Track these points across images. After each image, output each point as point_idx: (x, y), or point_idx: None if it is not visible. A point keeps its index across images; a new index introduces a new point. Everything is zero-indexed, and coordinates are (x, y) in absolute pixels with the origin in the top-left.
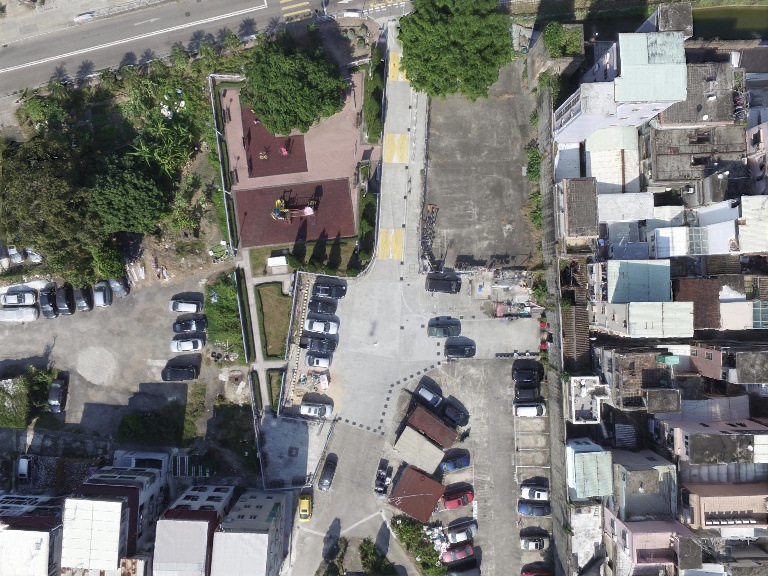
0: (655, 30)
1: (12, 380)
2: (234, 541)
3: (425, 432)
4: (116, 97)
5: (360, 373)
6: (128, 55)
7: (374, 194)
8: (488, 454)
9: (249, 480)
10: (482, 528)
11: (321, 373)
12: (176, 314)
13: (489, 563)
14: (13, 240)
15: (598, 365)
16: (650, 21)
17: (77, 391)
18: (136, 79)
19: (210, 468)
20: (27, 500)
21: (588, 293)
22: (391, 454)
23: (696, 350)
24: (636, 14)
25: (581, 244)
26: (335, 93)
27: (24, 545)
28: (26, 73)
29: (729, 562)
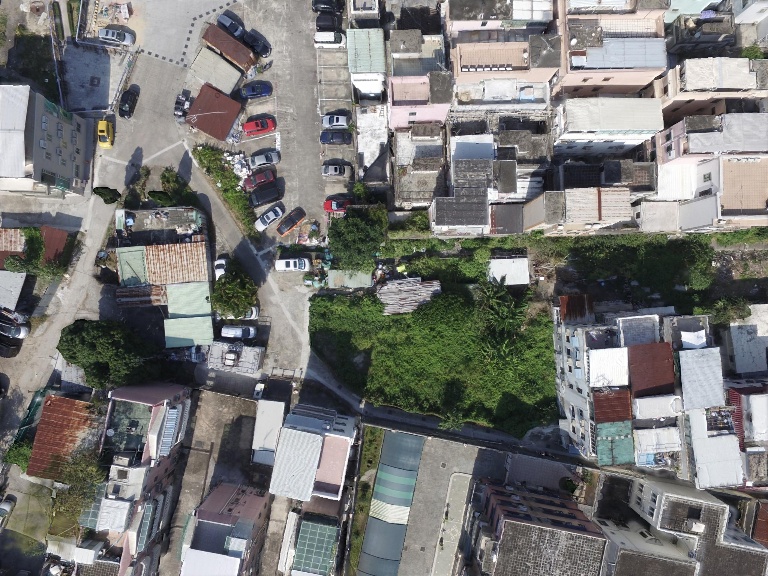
0: None
1: None
2: None
3: (219, 48)
4: None
5: (162, 6)
6: None
7: None
8: (291, 86)
9: None
10: (285, 159)
11: None
12: None
13: (293, 194)
14: None
15: None
16: None
17: None
18: None
19: None
20: None
21: None
22: (193, 85)
23: None
24: None
25: None
26: None
27: None
28: None
29: None
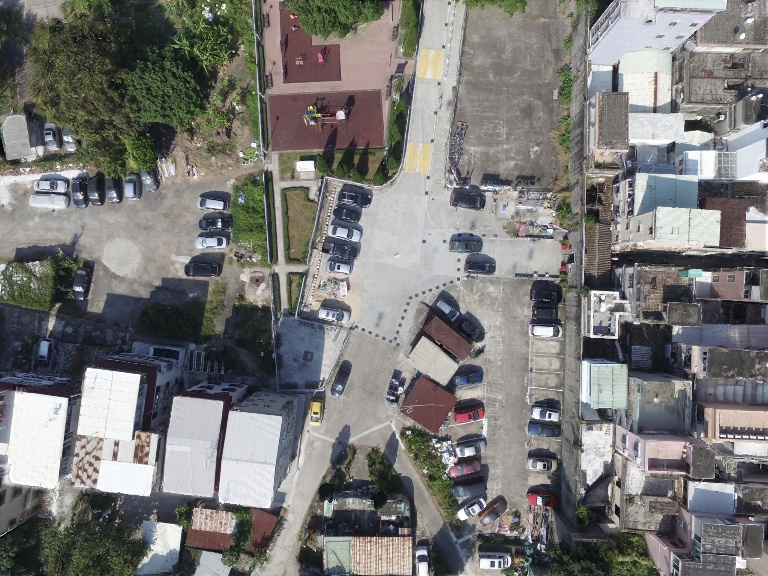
0: None
1: (39, 262)
2: (248, 420)
3: (441, 342)
4: None
5: (379, 283)
6: None
7: None
8: (501, 373)
9: (263, 381)
10: (491, 446)
11: (341, 280)
12: (203, 212)
13: (495, 482)
14: (53, 114)
15: (618, 285)
16: None
17: (101, 281)
18: None
19: (226, 365)
20: (46, 377)
21: (612, 214)
22: (405, 365)
23: (718, 276)
24: None
25: (609, 162)
26: None
27: (43, 407)
28: None
29: (740, 484)
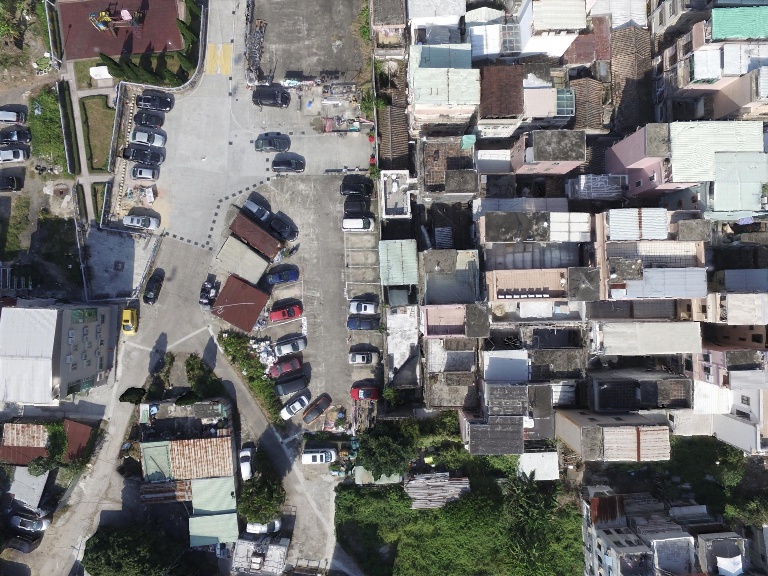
0: None
1: None
2: (22, 316)
3: (246, 239)
4: None
5: (188, 188)
6: None
7: None
8: (318, 270)
9: (74, 294)
10: (312, 344)
11: (148, 187)
12: None
13: (319, 380)
14: None
15: None
16: None
17: None
18: None
19: (33, 280)
20: None
21: None
22: (219, 269)
23: (513, 151)
24: None
25: (395, 42)
26: None
27: None
28: None
29: (534, 349)
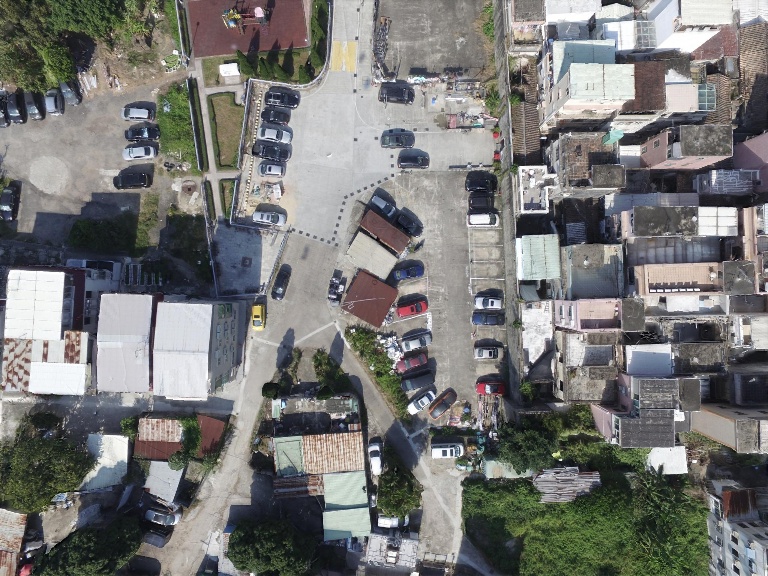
0: None
1: None
2: (178, 310)
3: (377, 235)
4: None
5: (314, 184)
6: None
7: None
8: (442, 266)
9: (202, 290)
10: (437, 340)
11: (274, 184)
12: (129, 124)
13: (444, 375)
14: None
15: (548, 163)
16: None
17: (29, 200)
18: None
19: (163, 276)
20: None
21: (539, 95)
22: (345, 265)
23: (646, 146)
24: None
25: (530, 39)
26: None
27: None
28: None
29: (677, 343)
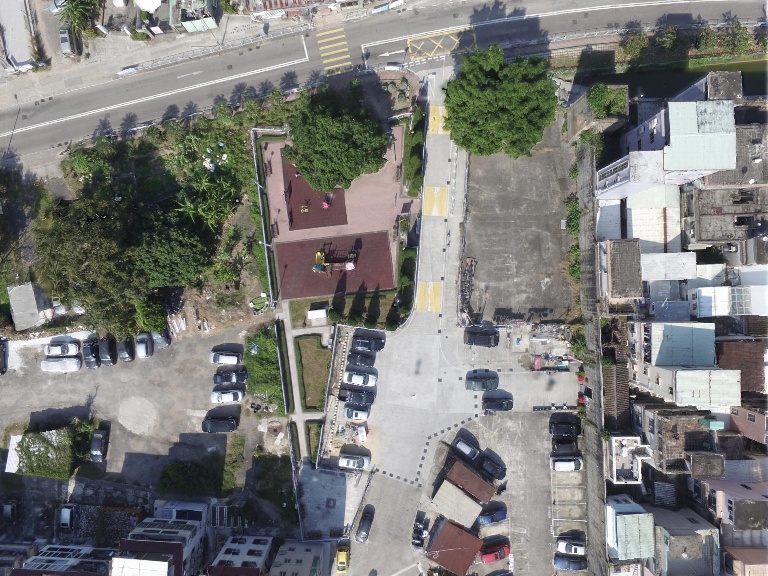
0: (703, 97)
1: (56, 431)
2: None
3: (463, 487)
4: (159, 150)
5: (398, 425)
6: (171, 108)
7: (414, 248)
8: (525, 507)
9: (287, 531)
10: None
11: (359, 425)
12: (216, 365)
13: None
14: (62, 299)
15: (638, 423)
16: (698, 87)
17: (118, 441)
18: (180, 134)
19: (249, 519)
20: (71, 552)
21: (628, 350)
22: (428, 506)
23: (737, 409)
24: (677, 68)
25: (623, 303)
26: (378, 151)
27: None
28: (70, 125)
29: None
